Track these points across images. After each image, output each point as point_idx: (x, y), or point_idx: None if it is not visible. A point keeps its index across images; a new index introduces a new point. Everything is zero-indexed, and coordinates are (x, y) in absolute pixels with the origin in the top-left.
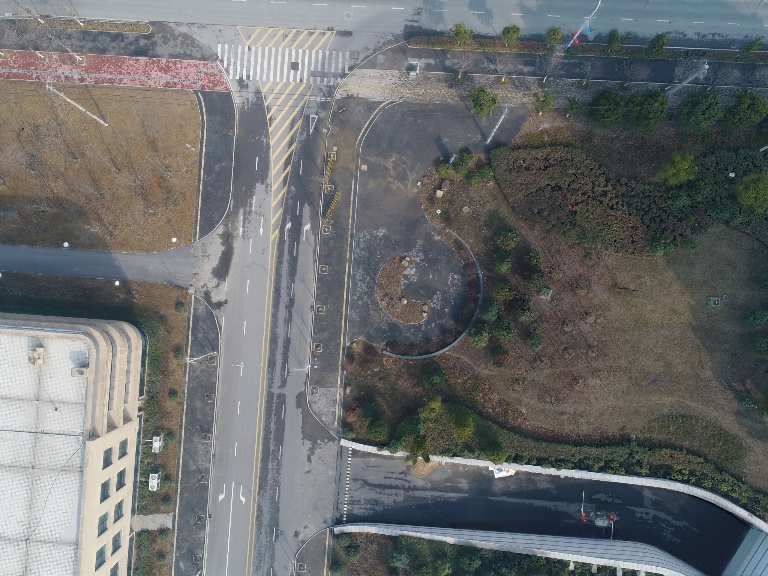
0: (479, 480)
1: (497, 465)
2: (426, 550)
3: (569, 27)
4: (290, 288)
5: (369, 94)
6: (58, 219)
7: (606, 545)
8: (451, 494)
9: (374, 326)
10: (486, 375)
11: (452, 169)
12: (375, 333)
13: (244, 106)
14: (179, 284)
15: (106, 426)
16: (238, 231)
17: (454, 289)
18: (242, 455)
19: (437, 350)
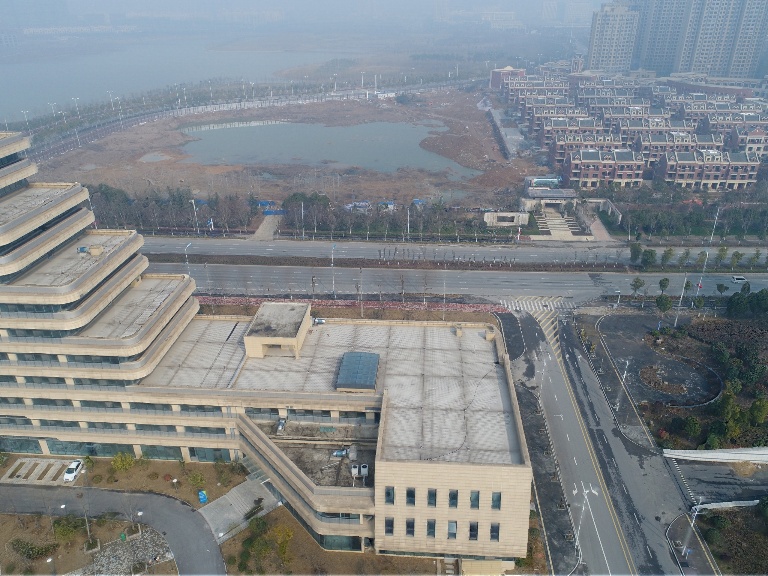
0: None
1: None
2: None
3: (691, 294)
4: (581, 380)
5: (593, 313)
6: None
7: None
8: None
9: (651, 395)
10: None
11: (660, 334)
12: (654, 399)
13: None
14: None
15: None
16: (535, 358)
17: (697, 379)
18: (582, 464)
19: None
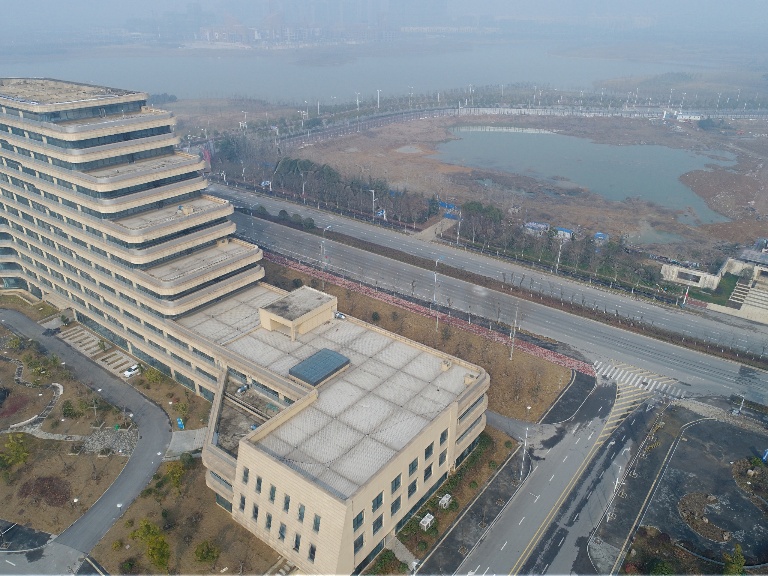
0: None
1: None
2: None
3: None
4: (600, 473)
5: (697, 411)
6: None
7: None
8: None
9: (671, 525)
10: None
11: (764, 466)
12: (670, 530)
13: (602, 386)
14: (513, 437)
15: None
16: (572, 431)
17: (759, 535)
18: (508, 553)
19: None
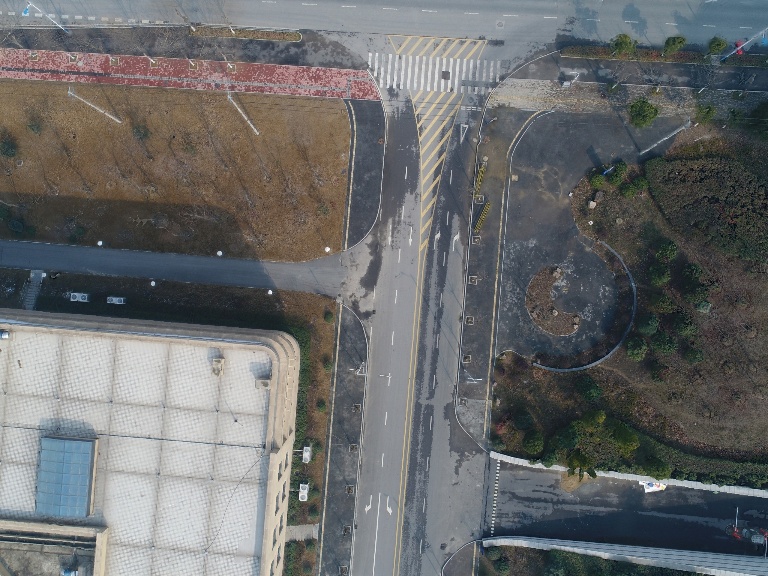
0: (629, 494)
1: (654, 480)
2: (580, 565)
3: (725, 37)
4: (439, 299)
5: (520, 104)
6: (208, 227)
7: (762, 562)
8: (600, 508)
9: (524, 338)
10: (641, 389)
11: (605, 180)
12: (525, 345)
13: (394, 115)
14: (327, 293)
15: (282, 438)
16: (387, 241)
17: (605, 301)
18: (389, 466)
19: (589, 363)
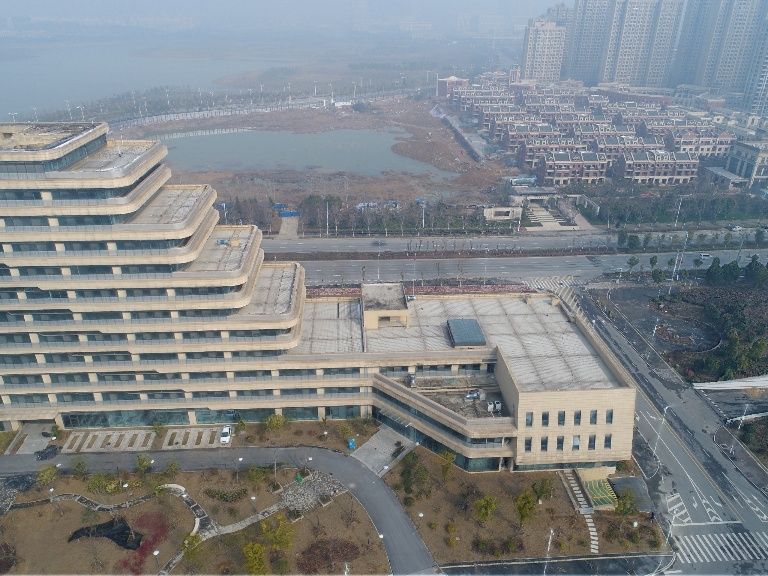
0: None
1: None
2: None
3: None
4: None
5: None
6: None
7: None
8: None
9: (669, 346)
10: None
11: None
12: None
13: None
14: None
15: None
16: None
17: (699, 332)
18: (636, 399)
19: None
